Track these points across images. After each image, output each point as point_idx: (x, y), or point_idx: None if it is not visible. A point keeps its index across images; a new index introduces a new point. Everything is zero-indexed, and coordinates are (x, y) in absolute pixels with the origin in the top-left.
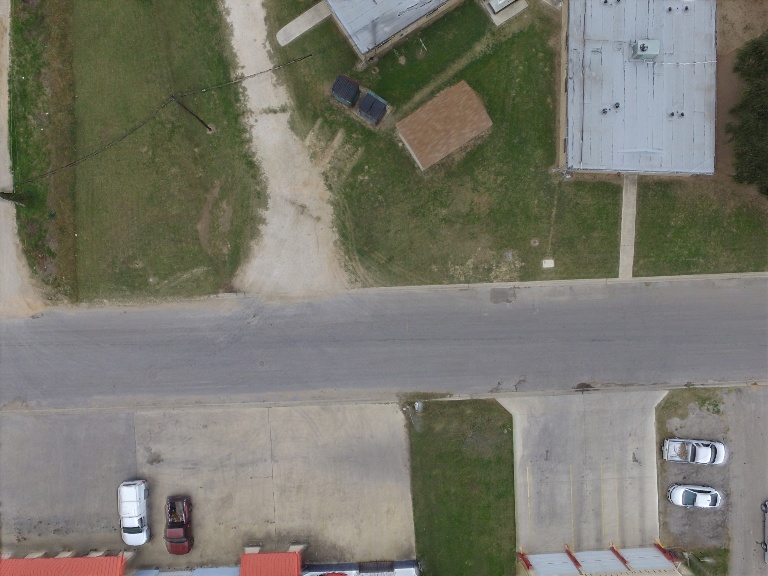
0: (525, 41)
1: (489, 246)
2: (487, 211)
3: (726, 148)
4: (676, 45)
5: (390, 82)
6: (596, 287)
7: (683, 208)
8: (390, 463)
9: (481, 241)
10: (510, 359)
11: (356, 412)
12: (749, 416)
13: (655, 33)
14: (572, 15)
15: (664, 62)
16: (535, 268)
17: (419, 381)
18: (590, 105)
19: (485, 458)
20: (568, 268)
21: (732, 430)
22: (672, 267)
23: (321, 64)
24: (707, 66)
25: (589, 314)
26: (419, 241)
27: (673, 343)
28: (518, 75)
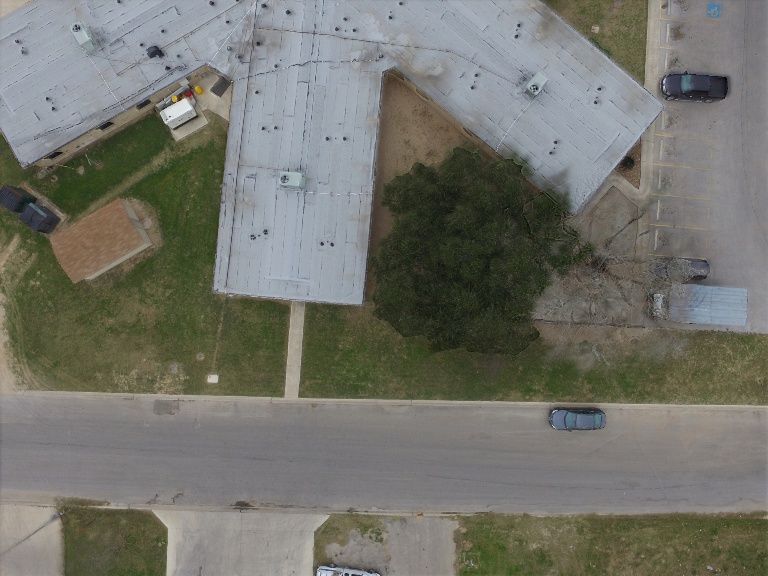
0: (202, 157)
1: (154, 357)
2: (154, 323)
3: (371, 282)
4: (332, 175)
5: (67, 191)
6: (261, 405)
7: (352, 332)
8: (45, 566)
9: (147, 352)
10: (169, 472)
11: (14, 513)
12: (413, 547)
13: (309, 162)
14: (229, 140)
15: (316, 192)
16: (199, 382)
17: (78, 487)
18: (240, 230)
19: (138, 569)
20: (232, 384)
21: (395, 560)
22: (339, 390)
23: (4, 169)
24: (363, 197)
25: (252, 432)
26: (85, 348)
27: (336, 467)
28: (193, 191)
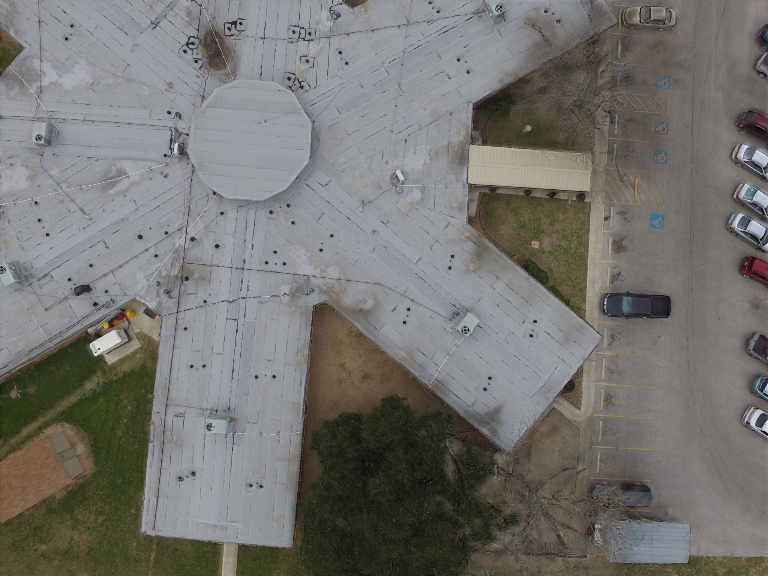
0: (135, 381)
1: None
2: (86, 550)
3: (301, 527)
4: (262, 413)
5: None
6: None
7: (287, 560)
8: None
9: None
10: None
11: None
12: None
13: (238, 402)
14: (158, 377)
15: (245, 432)
16: None
17: None
18: (169, 470)
19: None
20: None
21: None
22: None
23: None
24: (293, 436)
25: None
26: (17, 575)
27: None
28: (126, 415)
